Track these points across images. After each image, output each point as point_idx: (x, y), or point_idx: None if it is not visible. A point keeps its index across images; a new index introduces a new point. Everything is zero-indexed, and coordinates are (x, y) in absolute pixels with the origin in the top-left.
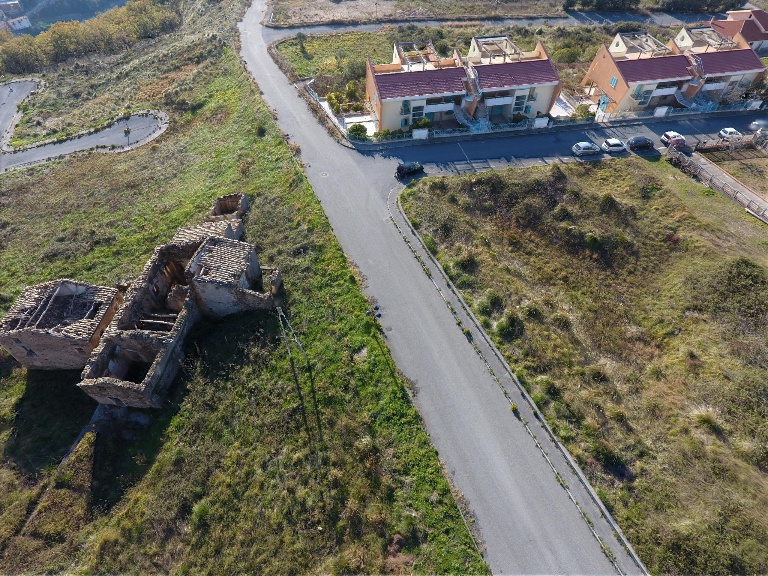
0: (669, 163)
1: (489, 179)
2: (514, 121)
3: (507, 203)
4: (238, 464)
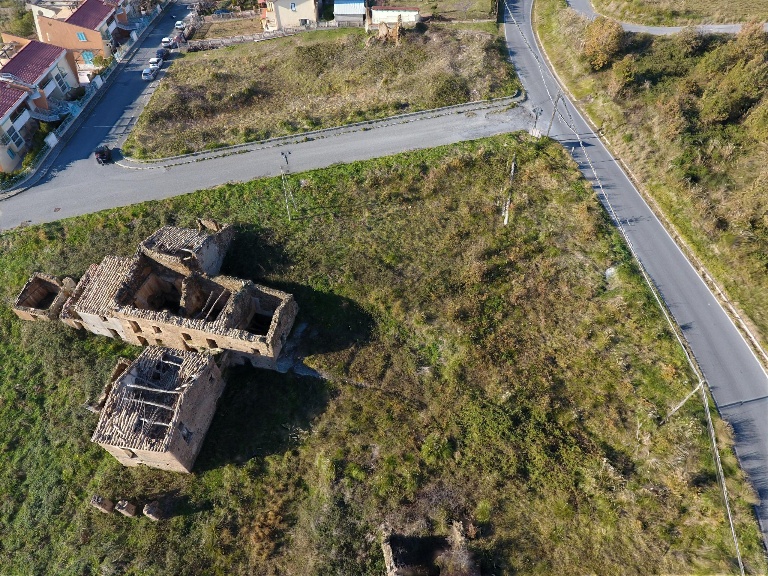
0: (191, 52)
1: (154, 115)
2: (77, 96)
3: (185, 116)
4: (365, 243)
